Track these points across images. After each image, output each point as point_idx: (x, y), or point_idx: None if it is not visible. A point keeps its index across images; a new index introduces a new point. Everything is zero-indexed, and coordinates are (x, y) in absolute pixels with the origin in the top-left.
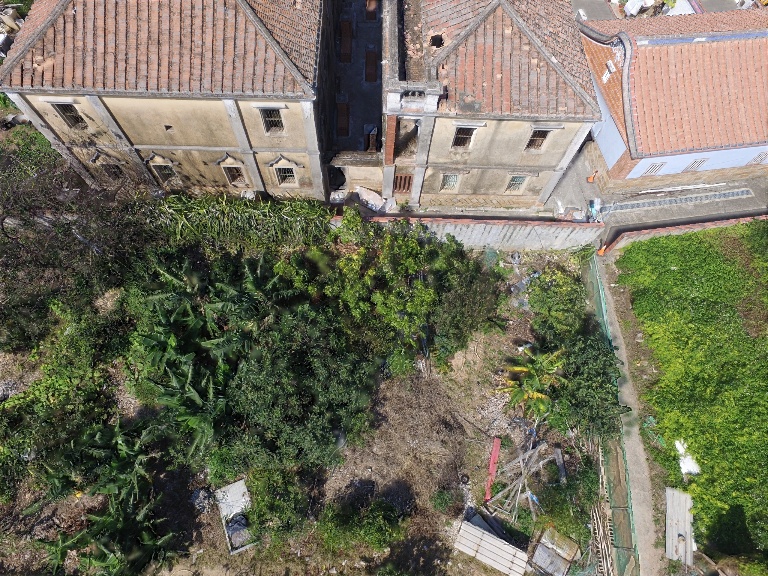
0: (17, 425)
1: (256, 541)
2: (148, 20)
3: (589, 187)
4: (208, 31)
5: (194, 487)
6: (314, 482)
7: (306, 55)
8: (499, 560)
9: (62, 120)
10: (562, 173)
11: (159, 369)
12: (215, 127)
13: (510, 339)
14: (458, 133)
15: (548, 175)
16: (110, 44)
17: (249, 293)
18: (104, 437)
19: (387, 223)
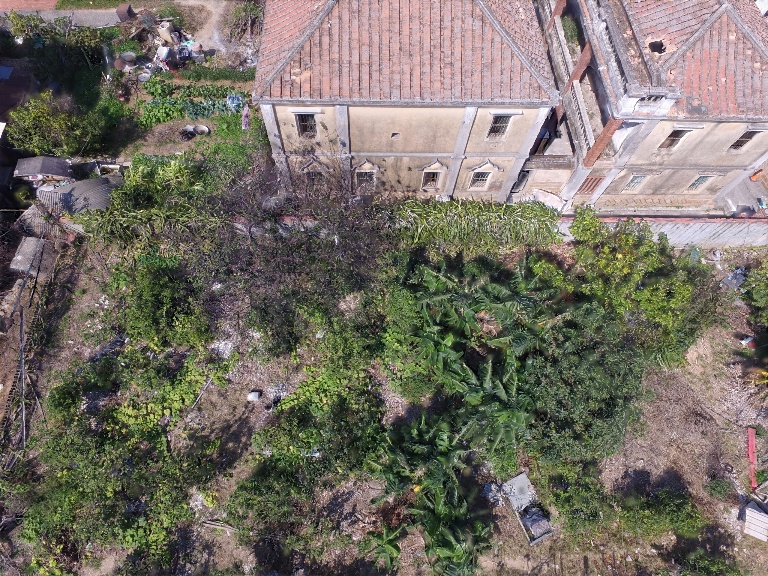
0: (299, 425)
1: (550, 532)
2: (399, 32)
3: (753, 185)
4: (457, 41)
5: (484, 481)
6: (589, 474)
7: (541, 63)
8: None
9: (296, 130)
10: (751, 172)
11: (438, 368)
12: (440, 134)
13: (730, 333)
14: (669, 135)
15: (735, 174)
16: (365, 56)
17: (520, 293)
18: (419, 434)
19: (620, 223)
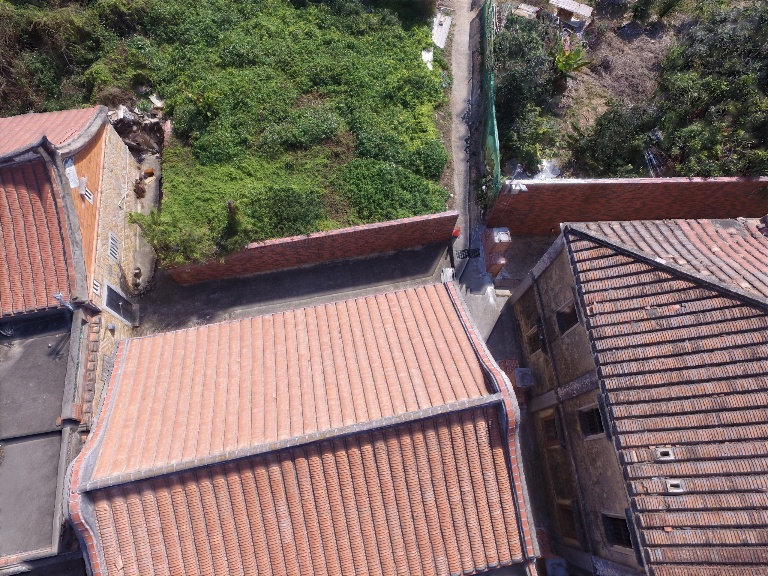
0: None
1: None
2: None
3: None
4: None
5: None
6: None
7: None
8: (567, 2)
9: None
10: None
11: None
12: None
13: None
14: None
15: None
16: None
17: None
18: None
19: None
